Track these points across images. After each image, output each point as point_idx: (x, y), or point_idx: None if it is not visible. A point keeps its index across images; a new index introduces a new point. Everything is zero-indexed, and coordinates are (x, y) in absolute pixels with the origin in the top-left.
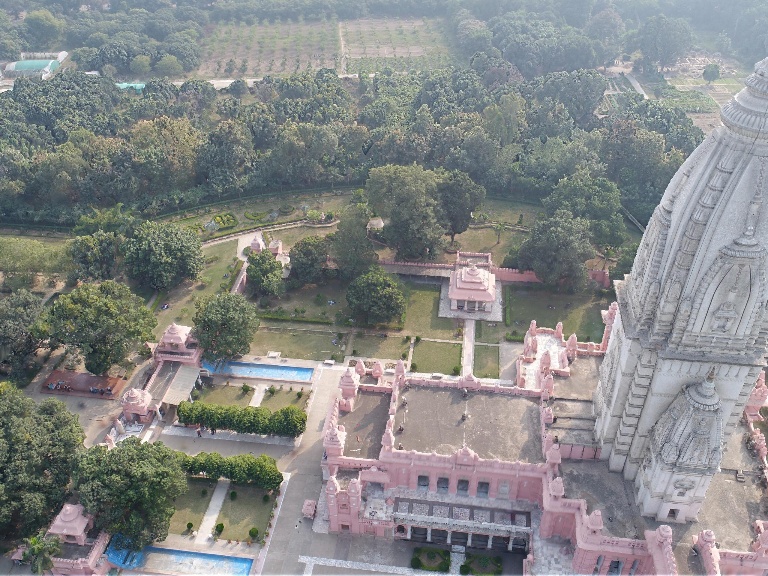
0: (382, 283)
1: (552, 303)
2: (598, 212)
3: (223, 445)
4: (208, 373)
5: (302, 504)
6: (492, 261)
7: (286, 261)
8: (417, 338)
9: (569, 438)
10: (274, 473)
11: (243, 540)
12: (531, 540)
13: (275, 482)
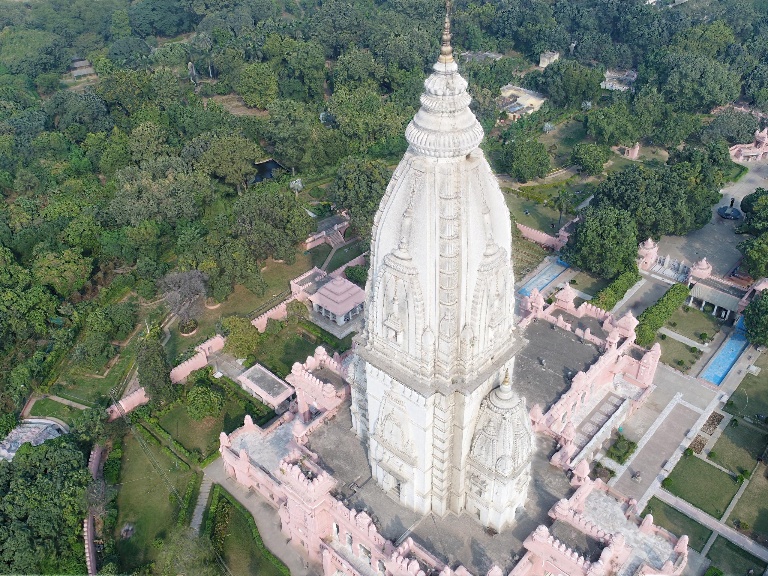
0: None
1: None
2: None
3: None
4: None
5: None
6: None
7: None
8: None
9: None
10: None
11: None
12: None
13: None
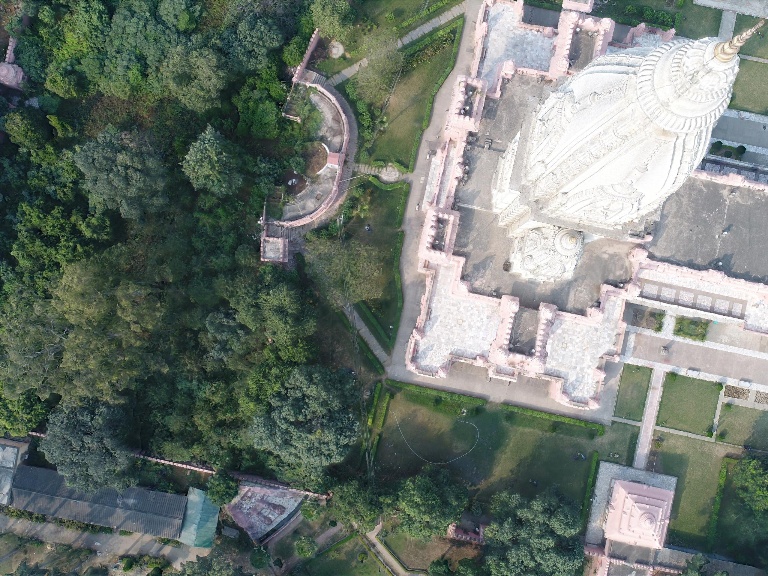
0: None
1: (531, 491)
2: None
3: None
4: None
5: None
6: None
7: None
8: None
9: None
10: None
11: None
12: None
13: None
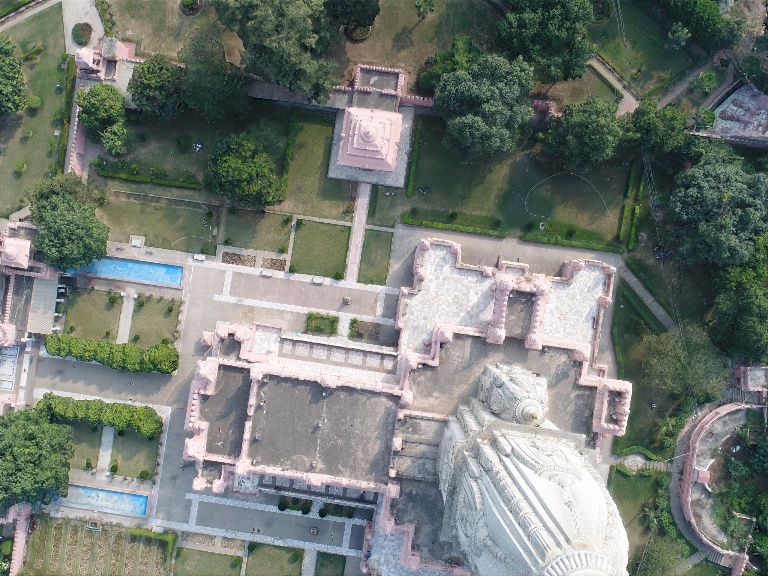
0: (247, 177)
1: None
2: (553, 41)
3: (102, 372)
4: (69, 274)
5: (184, 442)
6: (409, 62)
7: (130, 74)
8: (298, 224)
9: (413, 468)
10: (151, 432)
11: (137, 477)
12: (374, 517)
13: (155, 433)
